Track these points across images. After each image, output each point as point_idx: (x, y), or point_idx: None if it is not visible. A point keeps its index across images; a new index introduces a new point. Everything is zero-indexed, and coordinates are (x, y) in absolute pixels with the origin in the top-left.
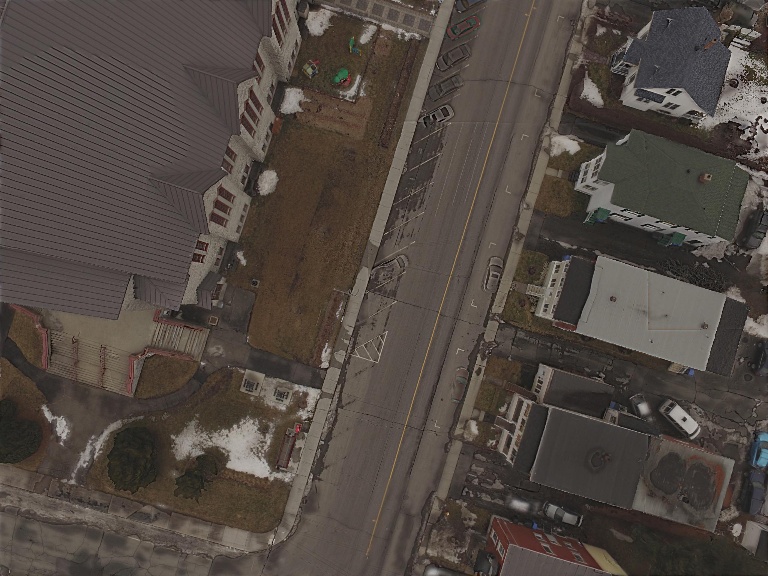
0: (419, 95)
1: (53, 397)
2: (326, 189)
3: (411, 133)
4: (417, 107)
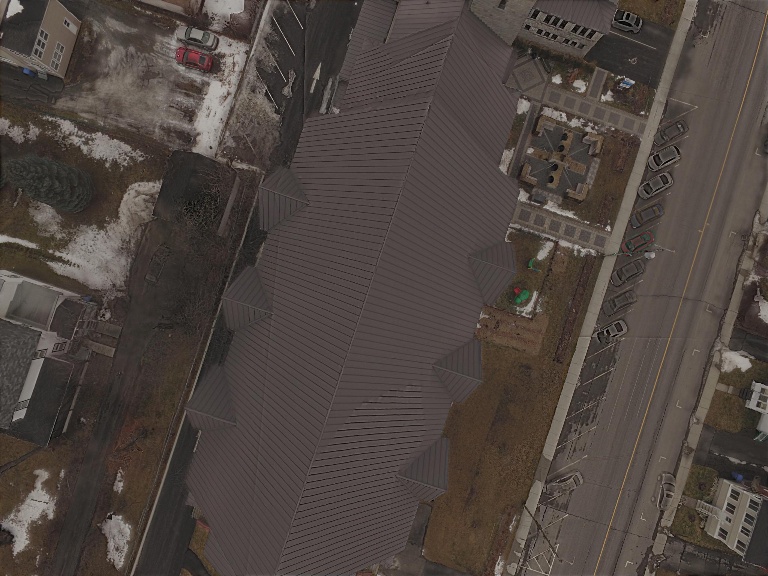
0: (594, 310)
1: None
2: (502, 404)
3: (585, 348)
4: (591, 322)
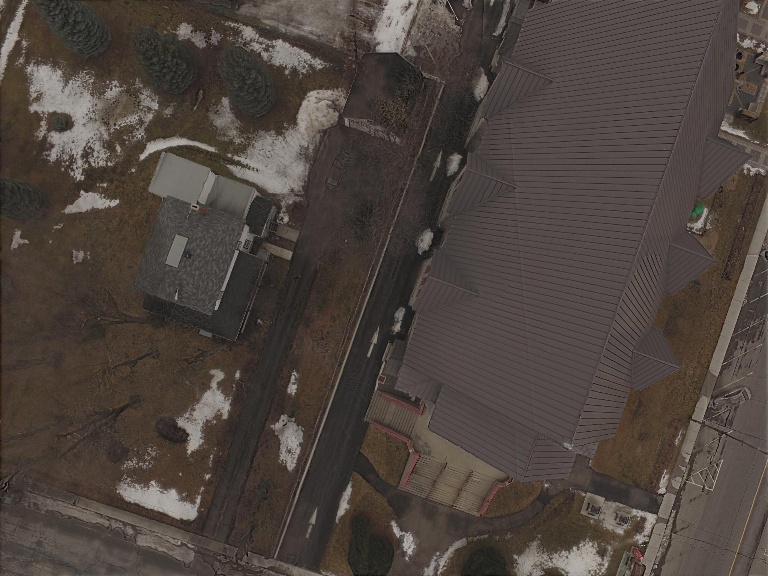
0: (762, 229)
1: (402, 513)
2: (671, 319)
3: (753, 266)
4: (759, 241)
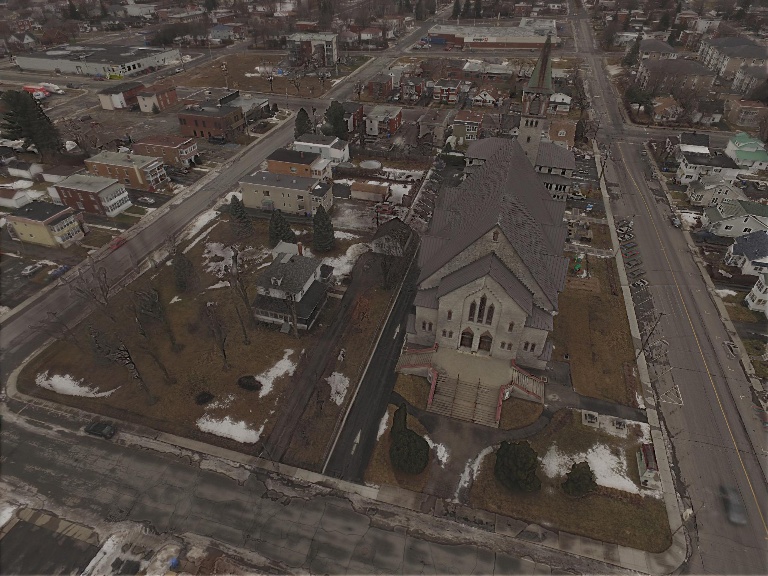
0: (623, 276)
1: (433, 429)
2: (590, 313)
3: (628, 290)
4: (625, 280)
